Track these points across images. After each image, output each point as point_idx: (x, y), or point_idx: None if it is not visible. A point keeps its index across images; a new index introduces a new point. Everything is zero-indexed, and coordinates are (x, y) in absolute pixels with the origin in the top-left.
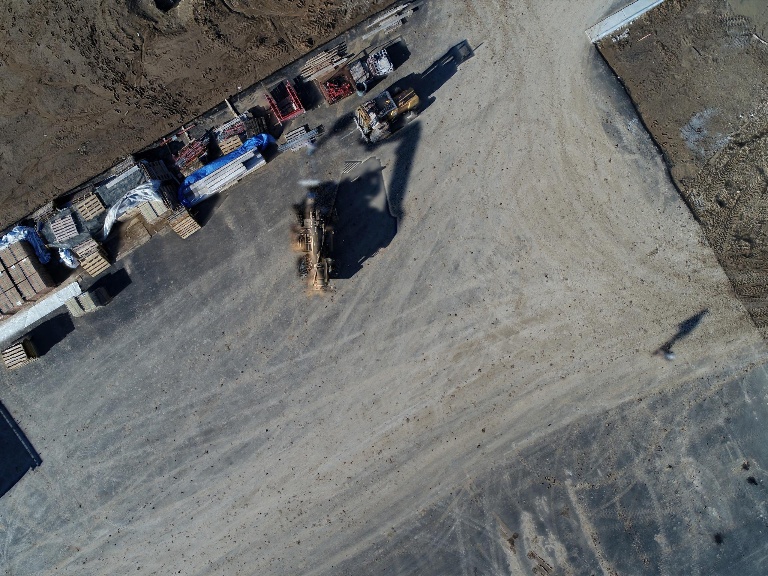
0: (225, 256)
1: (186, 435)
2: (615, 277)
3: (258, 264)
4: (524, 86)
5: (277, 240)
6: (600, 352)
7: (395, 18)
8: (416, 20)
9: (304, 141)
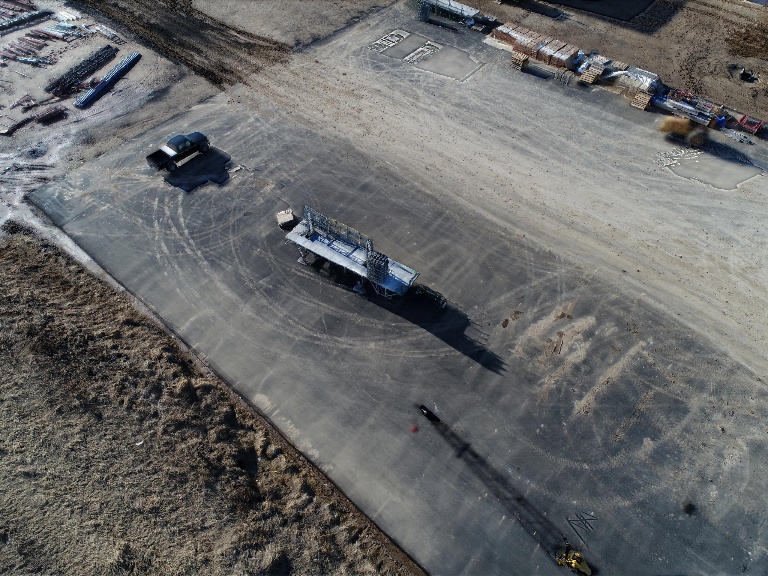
0: (637, 122)
1: (517, 128)
2: None
3: (645, 135)
4: None
5: (667, 140)
6: None
7: None
8: None
9: (737, 137)
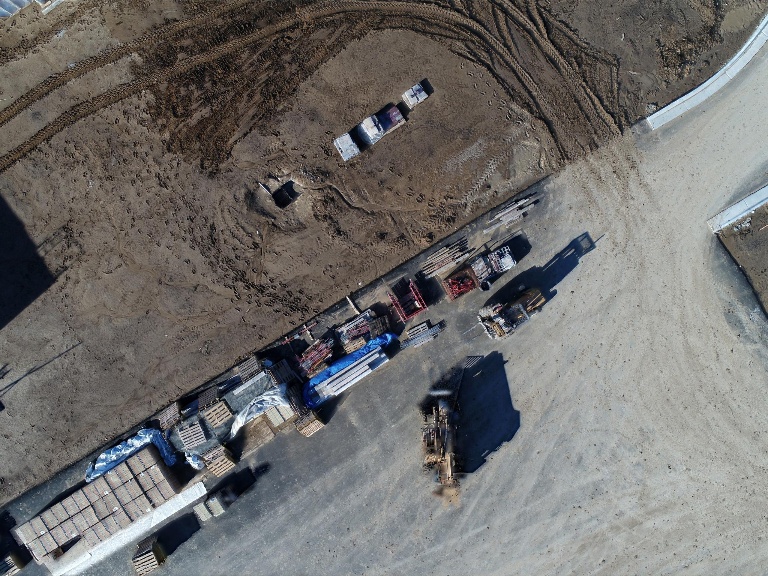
0: (349, 453)
1: None
2: (738, 466)
3: (382, 460)
4: (646, 277)
5: (400, 436)
6: (723, 541)
7: (516, 212)
8: (537, 213)
9: (426, 337)
